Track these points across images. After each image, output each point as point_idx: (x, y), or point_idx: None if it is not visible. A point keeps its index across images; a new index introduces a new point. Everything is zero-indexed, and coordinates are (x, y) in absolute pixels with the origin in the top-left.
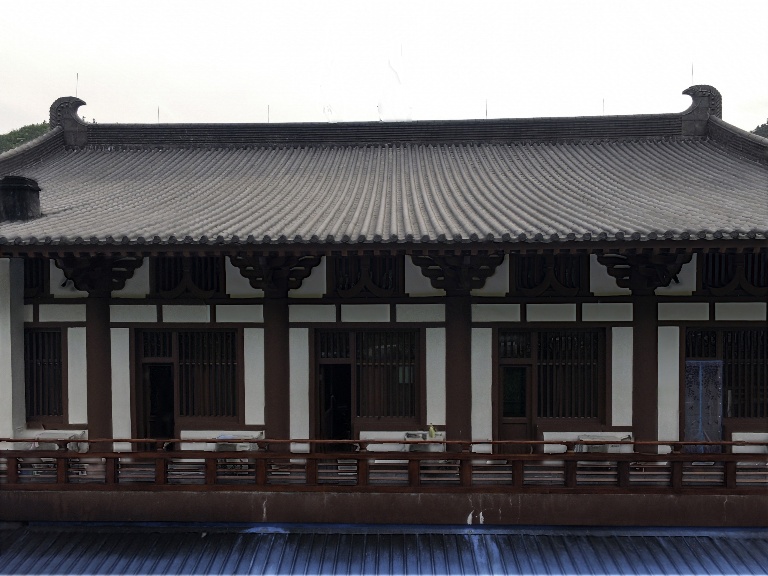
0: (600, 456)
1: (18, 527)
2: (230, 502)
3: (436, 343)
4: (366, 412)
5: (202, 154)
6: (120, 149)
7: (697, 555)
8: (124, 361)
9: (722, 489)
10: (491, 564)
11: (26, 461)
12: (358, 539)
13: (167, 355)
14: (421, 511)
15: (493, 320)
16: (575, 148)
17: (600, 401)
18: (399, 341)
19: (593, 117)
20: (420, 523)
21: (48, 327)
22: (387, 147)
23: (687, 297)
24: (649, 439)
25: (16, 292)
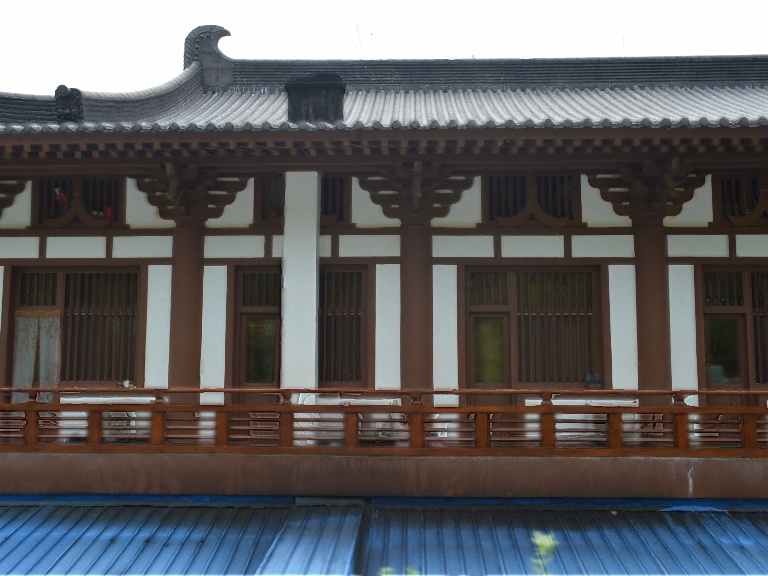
0: None
1: (364, 503)
2: (644, 471)
3: None
4: (767, 377)
5: (394, 96)
6: (276, 91)
7: None
8: (450, 307)
9: None
10: None
11: (367, 419)
12: None
13: (500, 302)
14: None
15: None
16: None
17: None
18: None
19: None
20: None
21: (351, 263)
22: (639, 89)
23: None
24: None
25: (318, 217)
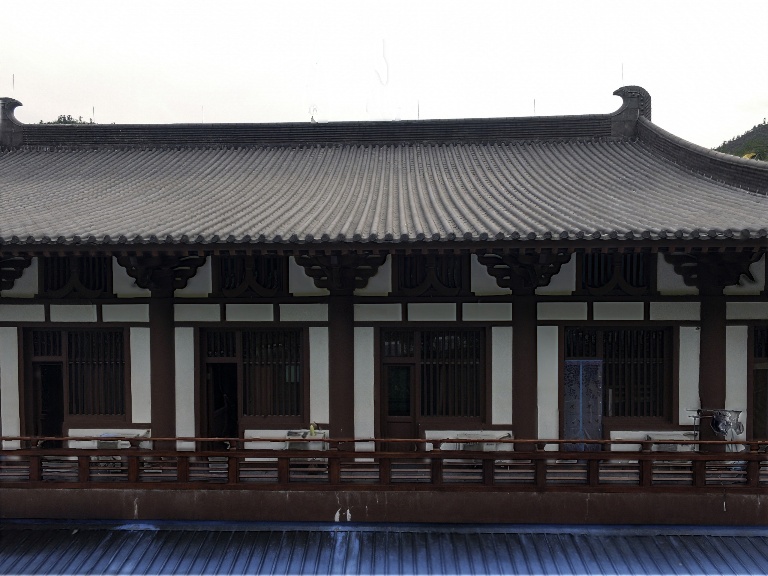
0: (465, 454)
1: None
2: (102, 499)
3: (319, 342)
4: (253, 411)
5: (134, 154)
6: (55, 149)
7: (553, 552)
8: (13, 360)
9: (585, 487)
10: (347, 561)
11: None
12: (225, 536)
13: (57, 354)
14: (289, 508)
15: (375, 319)
16: (504, 149)
17: (482, 400)
18: (285, 340)
19: (524, 118)
20: (288, 520)
21: None
22: (319, 148)
23: (566, 297)
24: (527, 437)
25: None
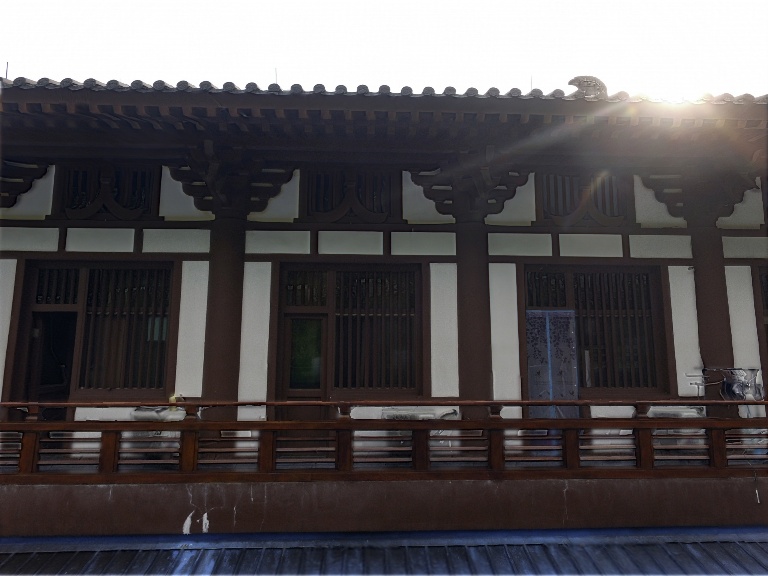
0: (386, 422)
1: None
2: None
3: (195, 282)
4: (94, 381)
5: None
6: None
7: (517, 570)
8: None
9: (560, 470)
10: None
11: None
12: None
13: None
14: (111, 513)
15: (273, 251)
16: None
17: (417, 364)
18: (150, 282)
19: None
20: (108, 533)
21: None
22: None
23: (525, 227)
24: (479, 413)
25: None
